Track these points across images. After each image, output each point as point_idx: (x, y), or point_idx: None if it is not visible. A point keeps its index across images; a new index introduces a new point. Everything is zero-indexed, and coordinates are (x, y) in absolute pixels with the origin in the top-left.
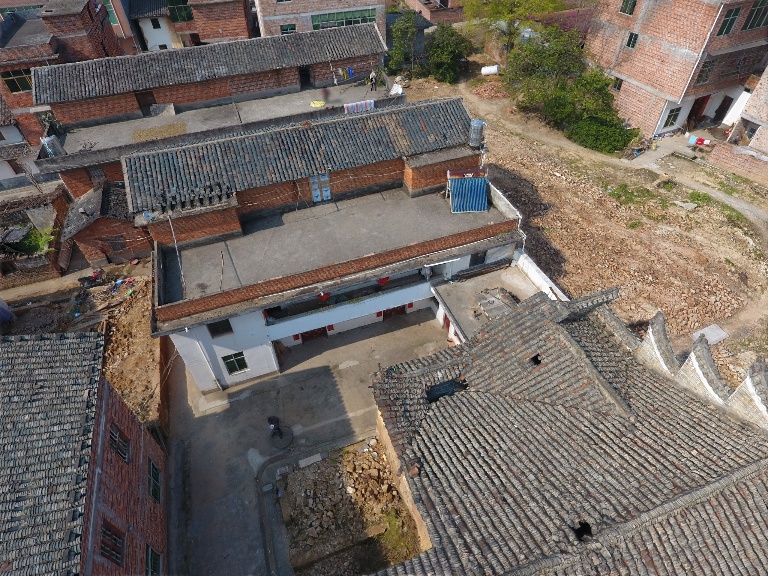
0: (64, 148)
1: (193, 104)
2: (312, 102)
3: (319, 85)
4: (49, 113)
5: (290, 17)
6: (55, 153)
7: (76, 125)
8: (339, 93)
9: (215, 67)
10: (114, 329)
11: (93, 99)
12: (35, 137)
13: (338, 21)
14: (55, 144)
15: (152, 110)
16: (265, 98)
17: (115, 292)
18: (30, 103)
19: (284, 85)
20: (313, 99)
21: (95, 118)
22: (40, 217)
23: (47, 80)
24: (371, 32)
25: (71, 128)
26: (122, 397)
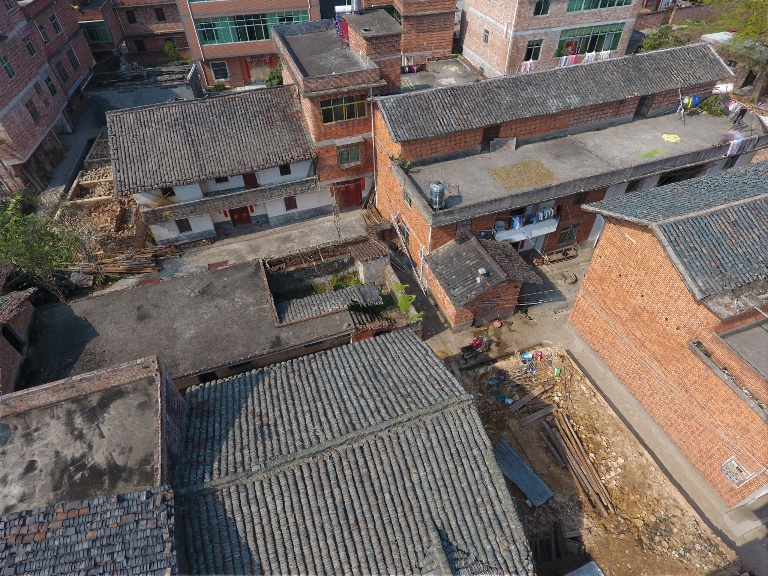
0: (426, 193)
1: (530, 137)
2: (663, 135)
3: (650, 114)
4: (399, 151)
5: (541, 32)
6: (441, 202)
7: (415, 163)
8: (681, 124)
9: (566, 96)
10: (573, 423)
11: (446, 134)
12: (326, 171)
13: (585, 36)
14: (443, 192)
15: (491, 145)
16: (599, 130)
17: (534, 370)
18: (336, 135)
19: (620, 115)
20: (659, 131)
21: (436, 155)
22: (373, 269)
23: (398, 112)
24: (708, 54)
25: (409, 166)
26: (664, 524)
